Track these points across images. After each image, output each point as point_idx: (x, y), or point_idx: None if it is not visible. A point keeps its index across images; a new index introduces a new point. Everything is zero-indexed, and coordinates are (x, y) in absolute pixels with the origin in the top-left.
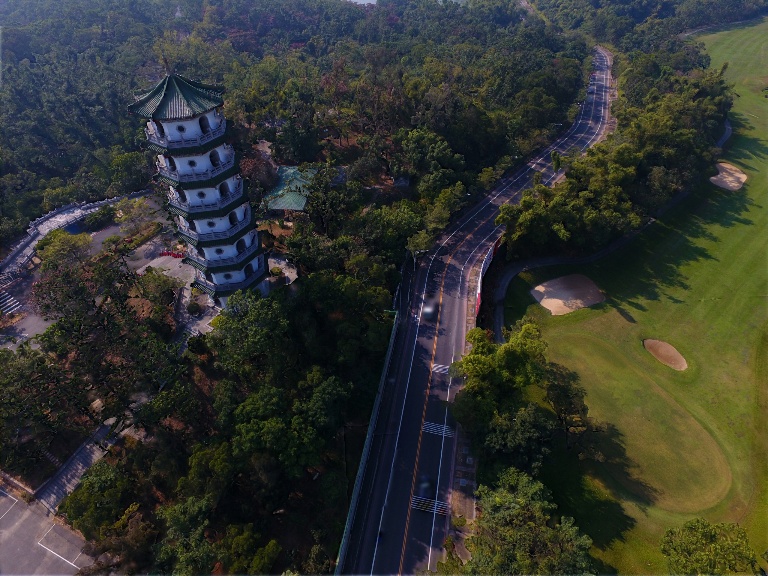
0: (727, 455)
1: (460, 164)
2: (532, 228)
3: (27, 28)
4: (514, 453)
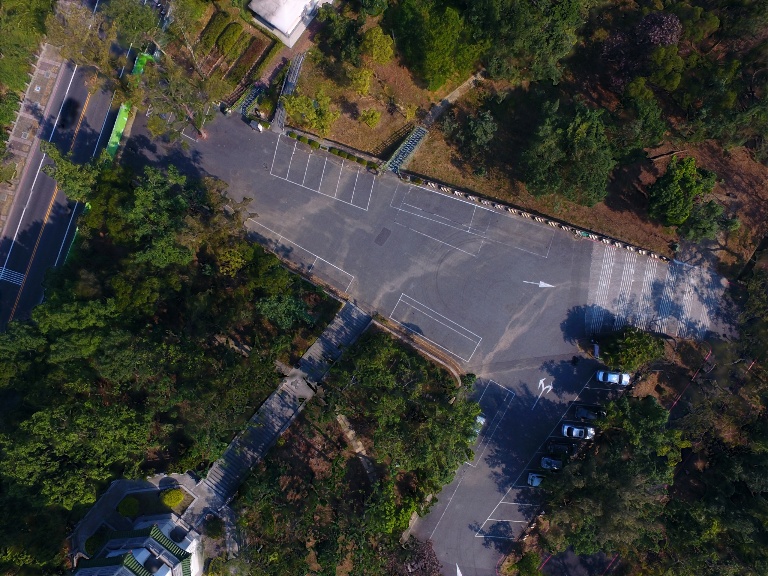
0: None
1: None
2: None
3: None
4: None
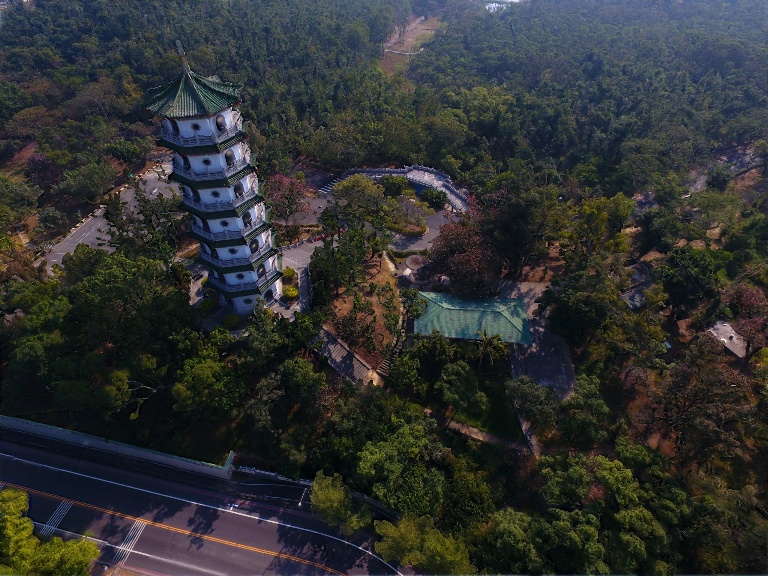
0: None
1: None
2: None
3: (766, 50)
4: None
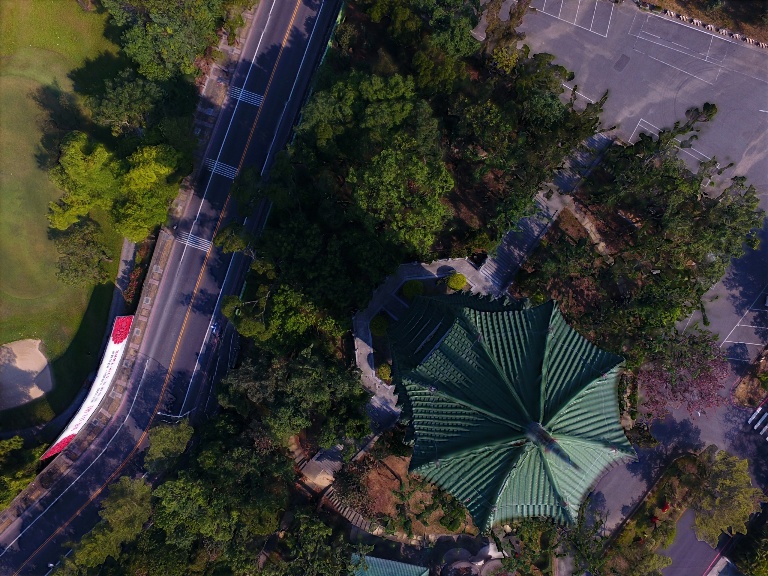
0: None
1: None
2: None
3: None
4: None
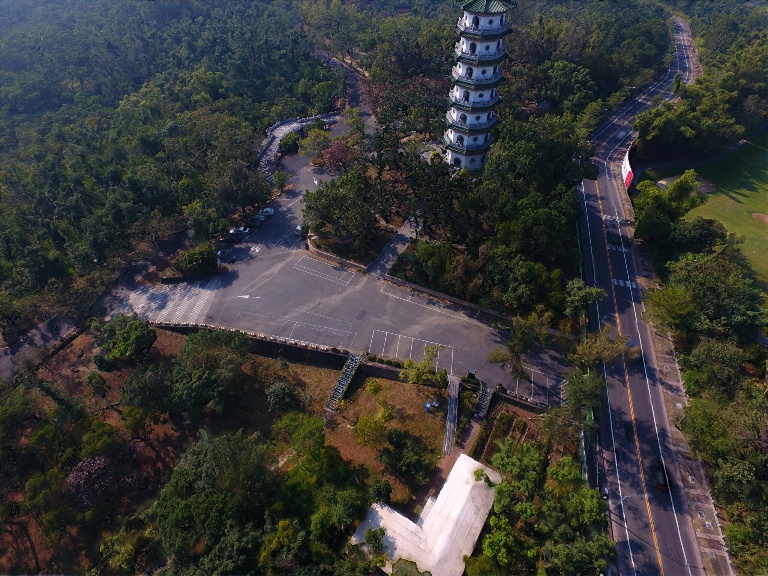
0: None
1: (594, 89)
2: (662, 131)
3: None
4: (689, 244)
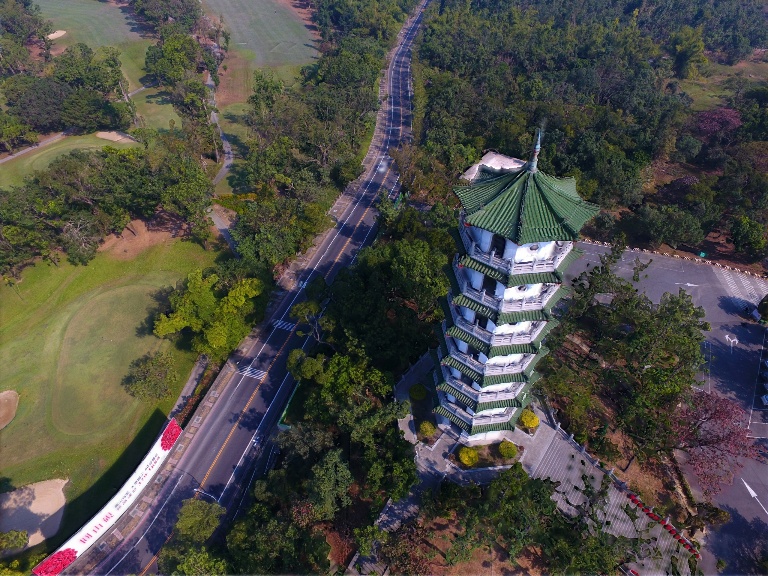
0: (75, 312)
1: None
2: None
3: None
4: None
